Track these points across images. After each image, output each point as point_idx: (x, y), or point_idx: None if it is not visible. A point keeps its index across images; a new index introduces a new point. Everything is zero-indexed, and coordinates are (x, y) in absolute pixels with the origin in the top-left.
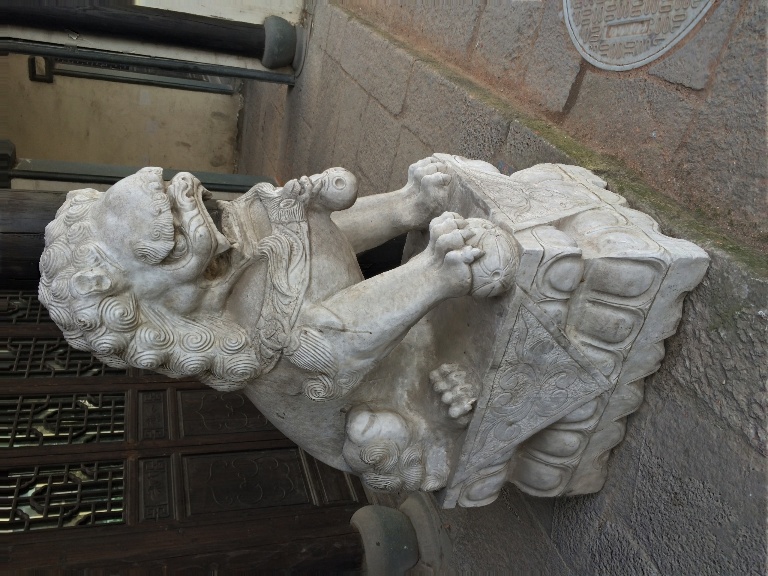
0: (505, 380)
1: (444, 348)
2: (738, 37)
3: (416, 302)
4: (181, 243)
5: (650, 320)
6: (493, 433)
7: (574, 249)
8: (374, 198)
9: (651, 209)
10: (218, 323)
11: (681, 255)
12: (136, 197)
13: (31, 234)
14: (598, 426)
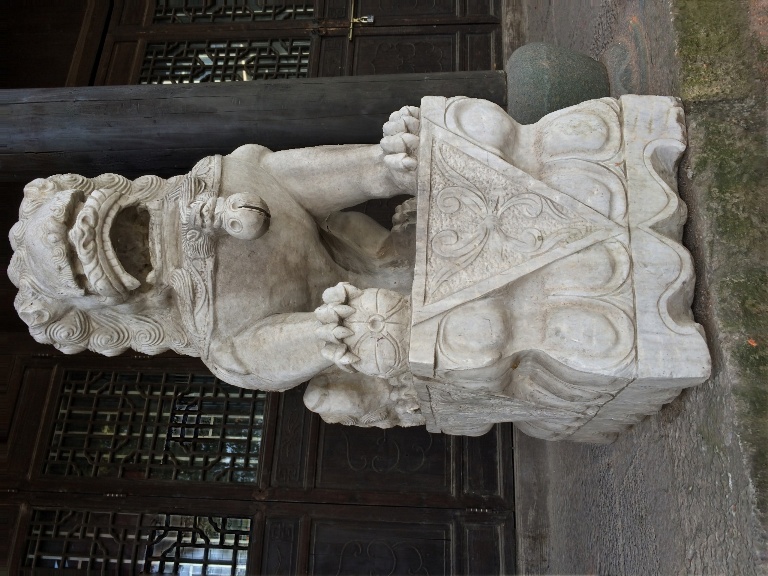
0: (443, 406)
1: None
2: None
3: (311, 366)
4: (92, 287)
5: (623, 397)
6: (453, 418)
7: (478, 363)
8: (343, 159)
9: (709, 231)
10: (167, 318)
11: (652, 374)
12: (39, 251)
13: (57, 153)
14: (585, 426)
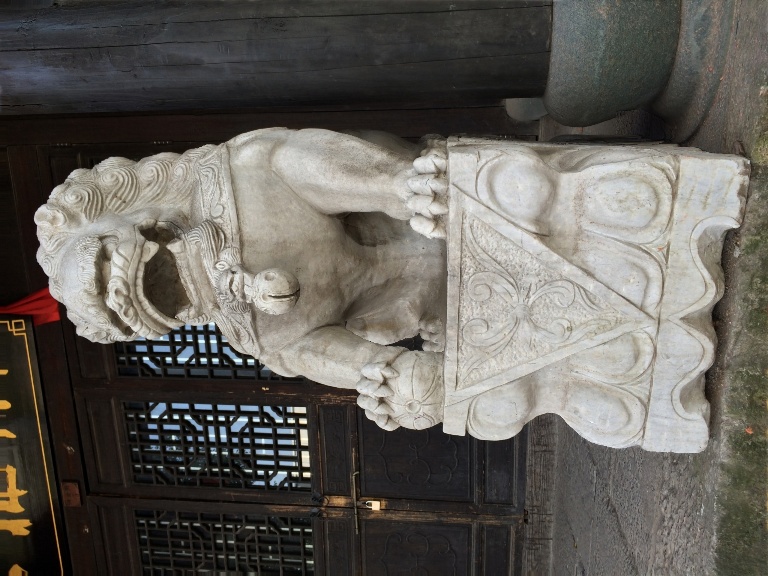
0: None
1: (443, 298)
2: None
3: None
4: None
5: None
6: None
7: (503, 438)
8: (364, 188)
9: (739, 323)
10: None
11: (654, 450)
12: (84, 316)
13: (35, 105)
14: None
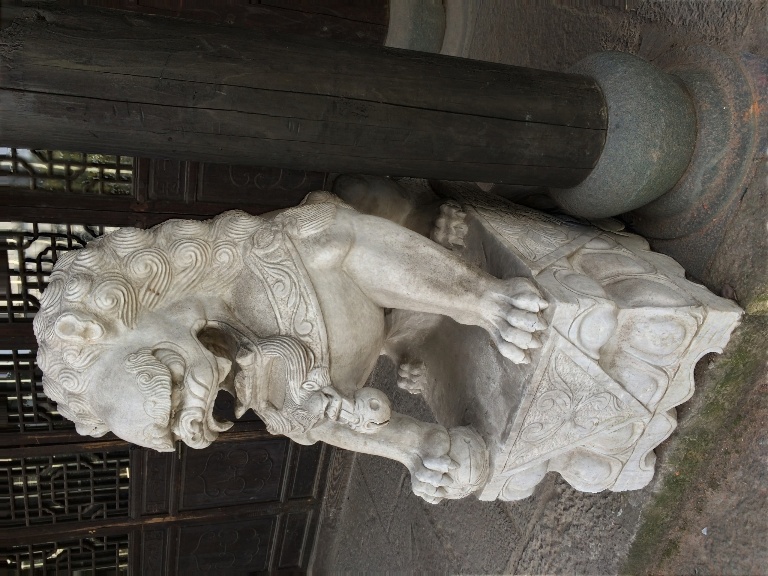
0: None
1: (432, 348)
2: None
3: None
4: None
5: None
6: None
7: None
8: (448, 304)
9: (697, 411)
10: None
11: None
12: None
13: None
14: None
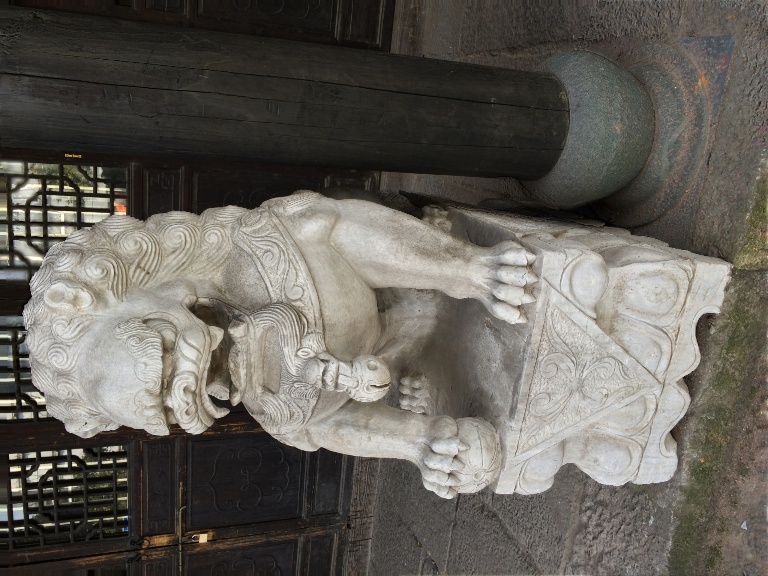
0: None
1: (431, 356)
2: None
3: None
4: None
5: None
6: None
7: None
8: (437, 271)
9: (708, 383)
10: None
11: (642, 483)
12: (129, 418)
13: None
14: None
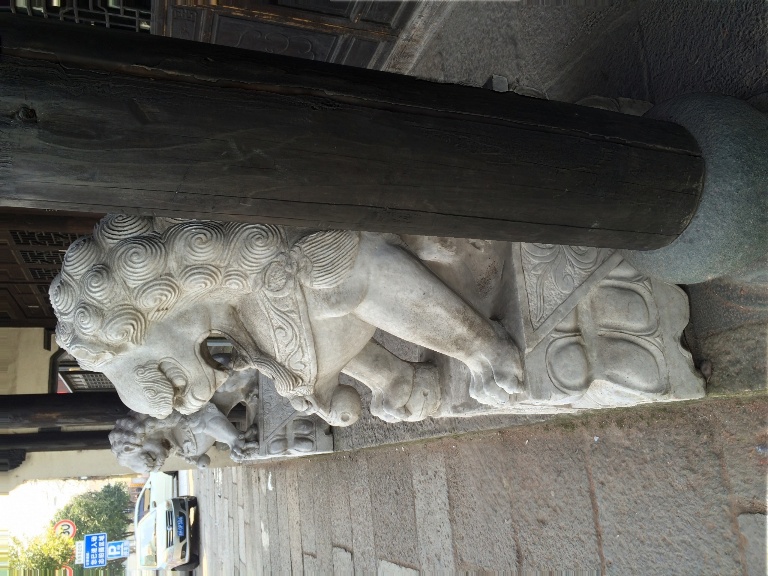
0: None
1: None
2: (737, 574)
3: None
4: None
5: None
6: None
7: None
8: None
9: None
10: None
11: None
12: None
13: None
14: None
